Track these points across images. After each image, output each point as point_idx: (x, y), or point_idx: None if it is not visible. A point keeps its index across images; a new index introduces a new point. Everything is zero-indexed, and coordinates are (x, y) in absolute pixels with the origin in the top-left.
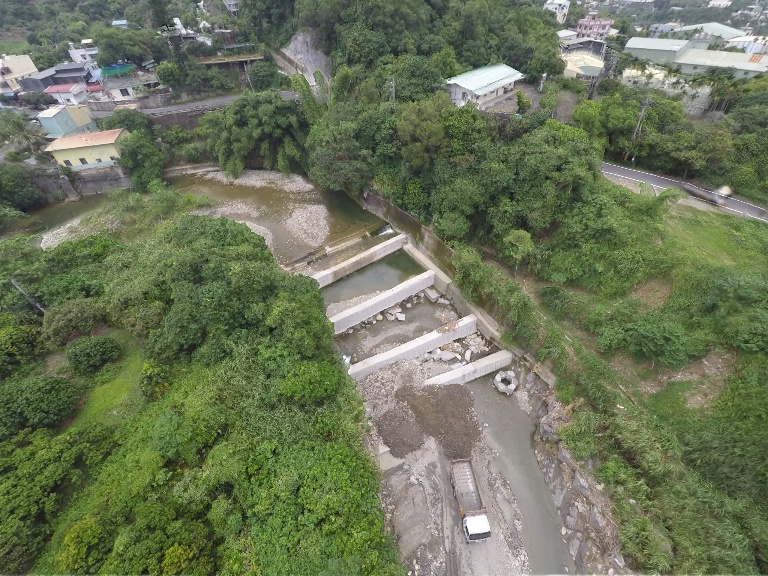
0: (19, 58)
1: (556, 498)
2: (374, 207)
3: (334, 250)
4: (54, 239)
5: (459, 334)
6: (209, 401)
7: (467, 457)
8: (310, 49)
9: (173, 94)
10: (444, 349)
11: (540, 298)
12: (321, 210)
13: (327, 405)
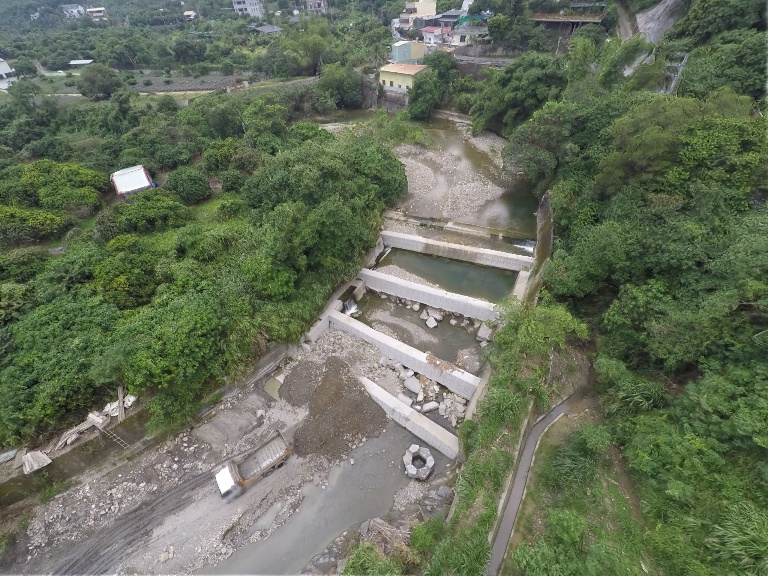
0: (429, 2)
1: (297, 575)
2: (542, 216)
3: (453, 229)
4: (337, 128)
5: (447, 382)
6: (217, 236)
7: (302, 452)
8: (663, 16)
9: (491, 46)
10: (419, 378)
11: (566, 441)
12: (495, 193)
13: (262, 302)
